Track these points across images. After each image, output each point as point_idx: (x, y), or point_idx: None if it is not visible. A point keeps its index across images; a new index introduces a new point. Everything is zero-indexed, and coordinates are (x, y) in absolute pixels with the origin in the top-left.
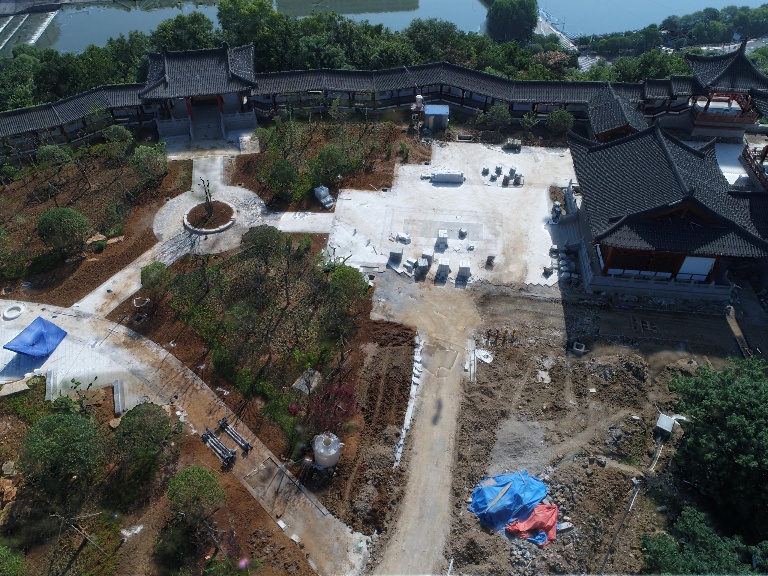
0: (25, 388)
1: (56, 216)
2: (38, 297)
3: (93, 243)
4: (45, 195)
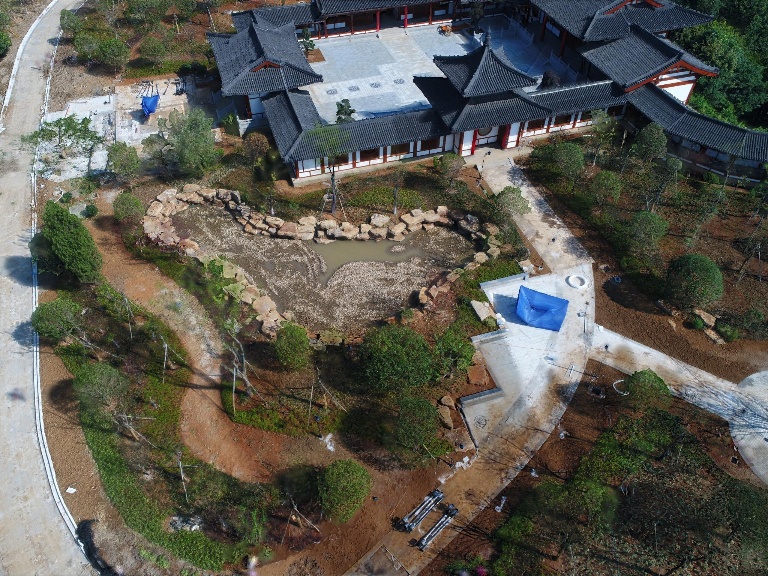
0: (481, 317)
1: (697, 265)
2: (603, 294)
3: (697, 316)
4: (760, 252)
